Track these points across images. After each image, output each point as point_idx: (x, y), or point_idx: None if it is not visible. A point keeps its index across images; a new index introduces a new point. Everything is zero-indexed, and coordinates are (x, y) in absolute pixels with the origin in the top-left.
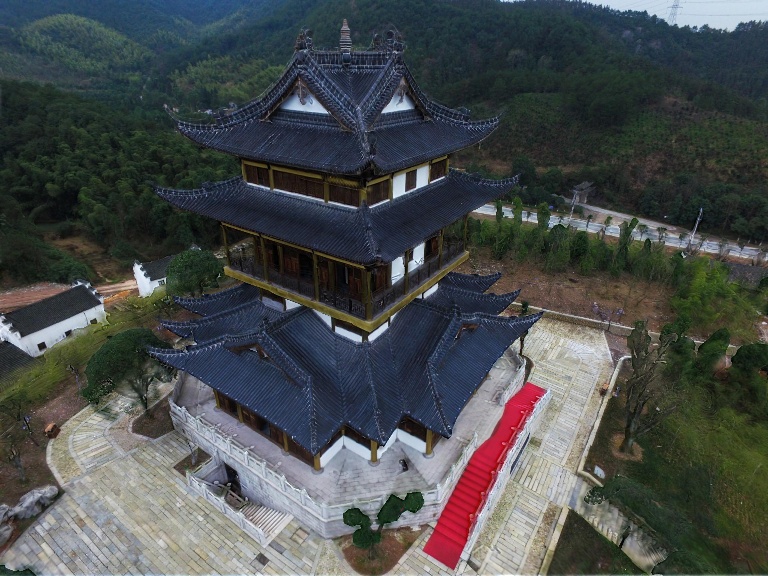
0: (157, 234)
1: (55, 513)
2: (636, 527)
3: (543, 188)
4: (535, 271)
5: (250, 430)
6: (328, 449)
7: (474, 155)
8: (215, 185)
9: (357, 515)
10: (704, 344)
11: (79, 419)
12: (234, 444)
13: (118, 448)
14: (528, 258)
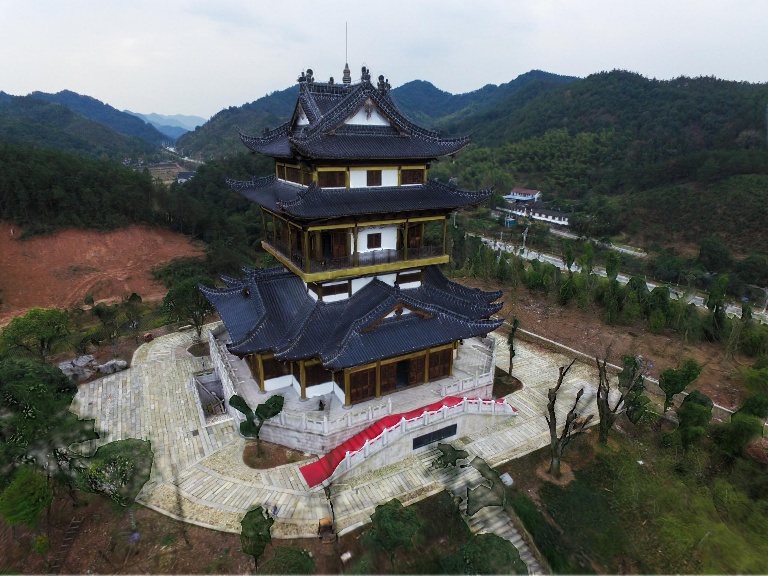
0: None
1: (117, 375)
2: (522, 542)
3: (736, 276)
4: (594, 319)
5: (243, 360)
6: (274, 378)
7: (662, 236)
8: (259, 179)
9: (236, 399)
10: (737, 411)
11: (167, 337)
12: (222, 360)
13: (173, 356)
14: (600, 310)
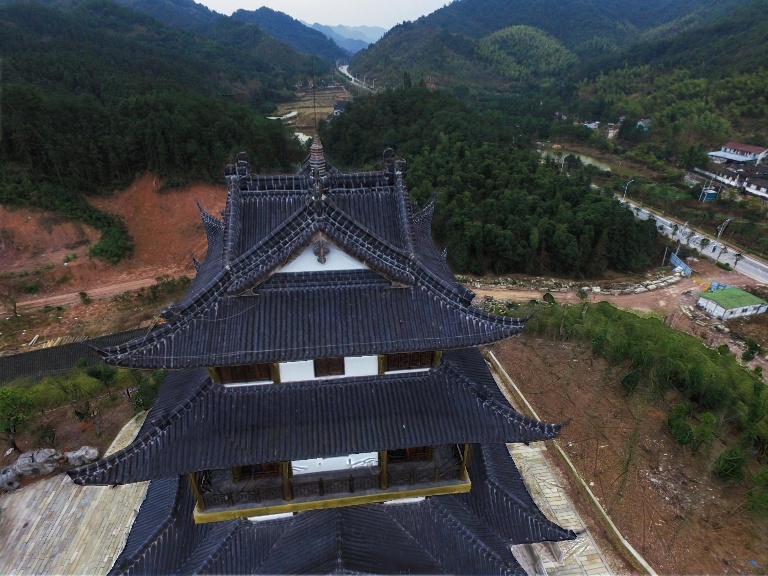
0: (447, 243)
1: None
2: None
3: None
4: None
5: None
6: None
7: None
8: None
9: None
10: None
11: None
12: None
13: None
14: None
